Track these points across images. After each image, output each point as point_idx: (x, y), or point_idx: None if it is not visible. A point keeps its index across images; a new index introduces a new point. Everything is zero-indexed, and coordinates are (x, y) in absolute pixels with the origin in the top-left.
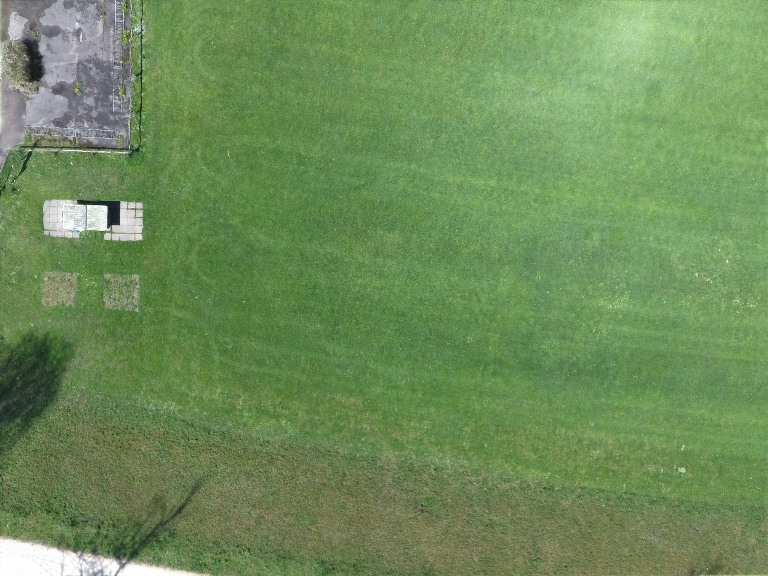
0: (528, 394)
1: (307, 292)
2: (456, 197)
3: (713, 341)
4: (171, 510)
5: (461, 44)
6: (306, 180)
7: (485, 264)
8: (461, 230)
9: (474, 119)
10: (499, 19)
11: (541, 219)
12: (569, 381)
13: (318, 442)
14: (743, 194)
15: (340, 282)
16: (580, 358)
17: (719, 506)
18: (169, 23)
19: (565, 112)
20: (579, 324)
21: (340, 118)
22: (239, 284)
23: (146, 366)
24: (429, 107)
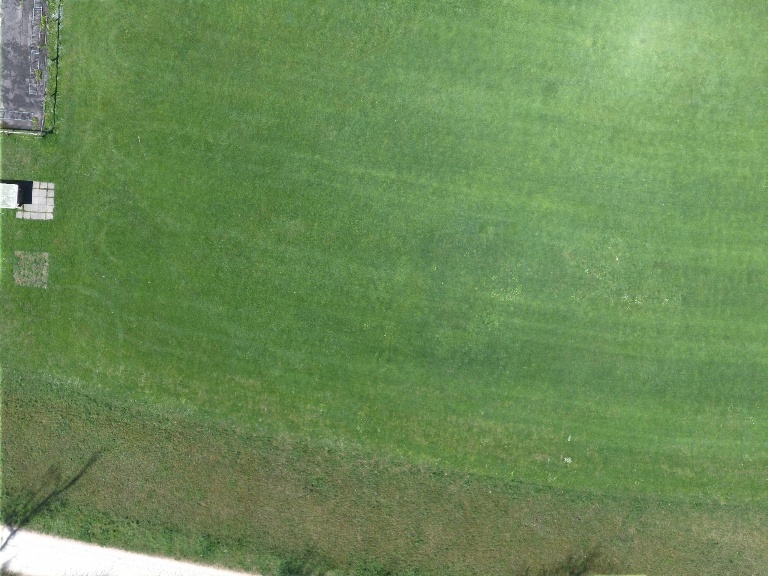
0: (421, 381)
1: (211, 275)
2: (357, 188)
3: (601, 336)
4: (65, 481)
5: (365, 41)
6: (213, 167)
7: (383, 254)
8: (361, 220)
9: (376, 113)
10: (402, 18)
11: (438, 212)
12: (461, 370)
13: (216, 421)
14: (633, 194)
15: (243, 266)
16: (472, 348)
17: (603, 496)
18: (86, 11)
19: (464, 109)
20: (472, 315)
21: (247, 108)
22: (145, 265)
23: (52, 341)
24: (333, 100)
